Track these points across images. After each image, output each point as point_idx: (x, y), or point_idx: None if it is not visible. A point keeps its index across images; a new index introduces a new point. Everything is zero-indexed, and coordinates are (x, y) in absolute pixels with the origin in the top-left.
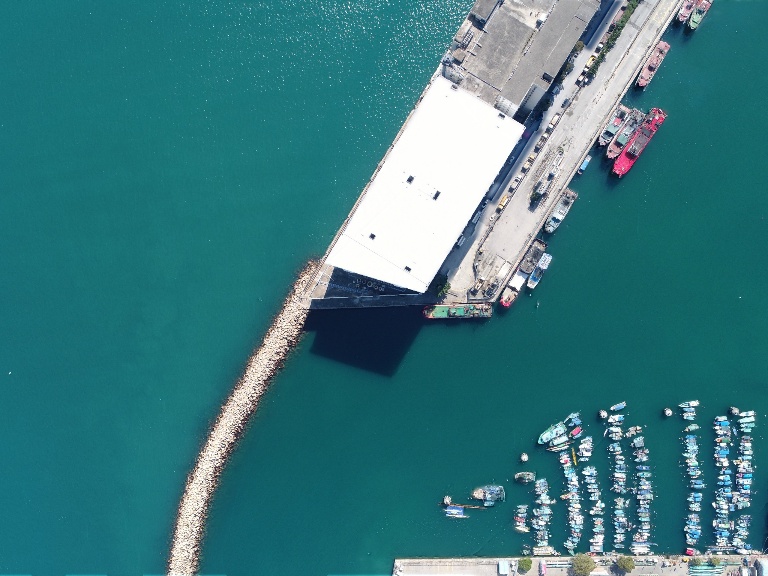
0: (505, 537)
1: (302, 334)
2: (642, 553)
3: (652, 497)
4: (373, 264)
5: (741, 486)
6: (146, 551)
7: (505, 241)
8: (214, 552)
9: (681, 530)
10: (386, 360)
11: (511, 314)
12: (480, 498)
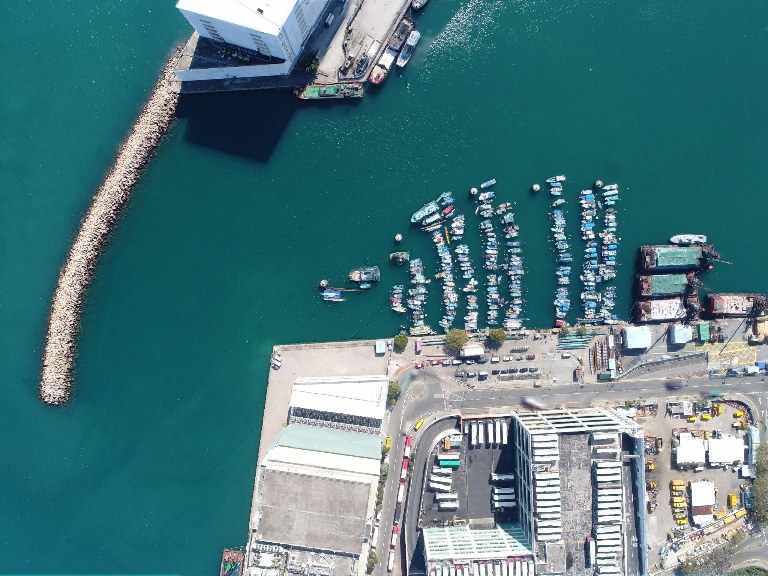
0: (382, 319)
1: (174, 121)
2: (514, 328)
3: (523, 272)
4: (225, 7)
5: (607, 258)
6: (19, 350)
7: (374, 20)
8: (91, 349)
9: (551, 304)
10: (260, 145)
11: (382, 95)
12: (356, 280)
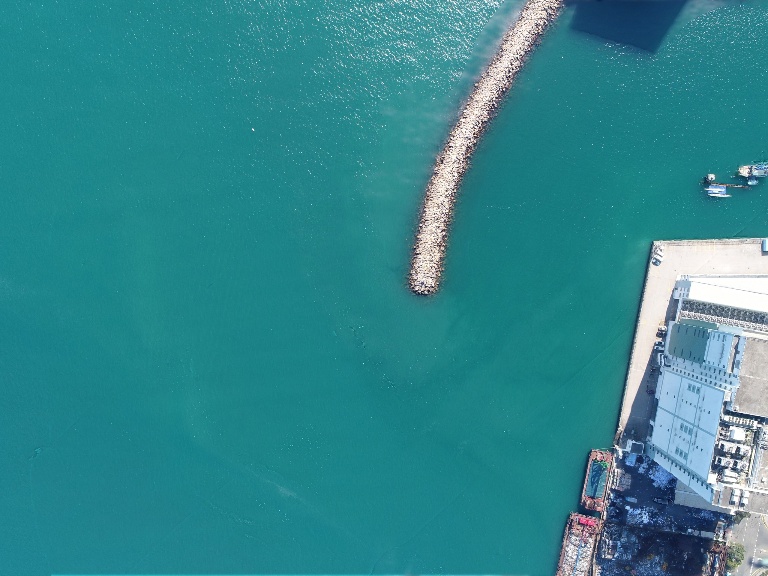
0: (767, 217)
1: (561, 8)
2: None
3: None
4: None
5: None
6: (389, 239)
7: None
8: (460, 240)
9: None
10: (648, 35)
11: None
12: (745, 175)
